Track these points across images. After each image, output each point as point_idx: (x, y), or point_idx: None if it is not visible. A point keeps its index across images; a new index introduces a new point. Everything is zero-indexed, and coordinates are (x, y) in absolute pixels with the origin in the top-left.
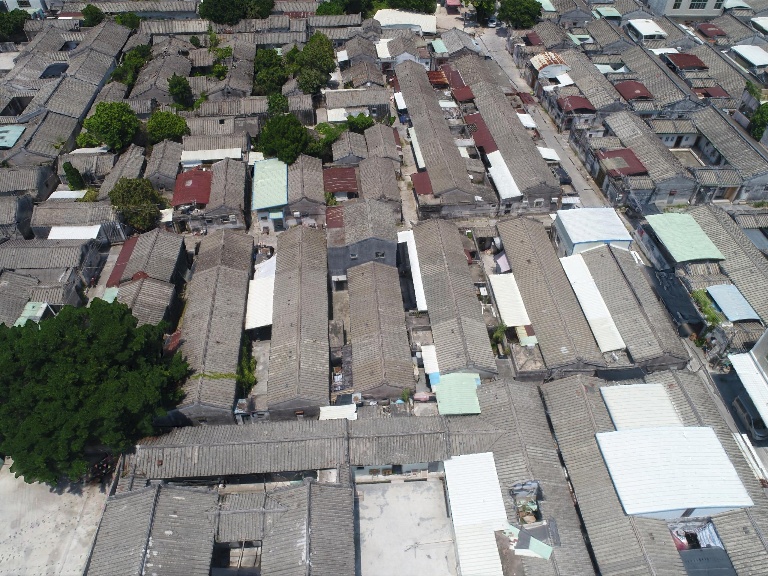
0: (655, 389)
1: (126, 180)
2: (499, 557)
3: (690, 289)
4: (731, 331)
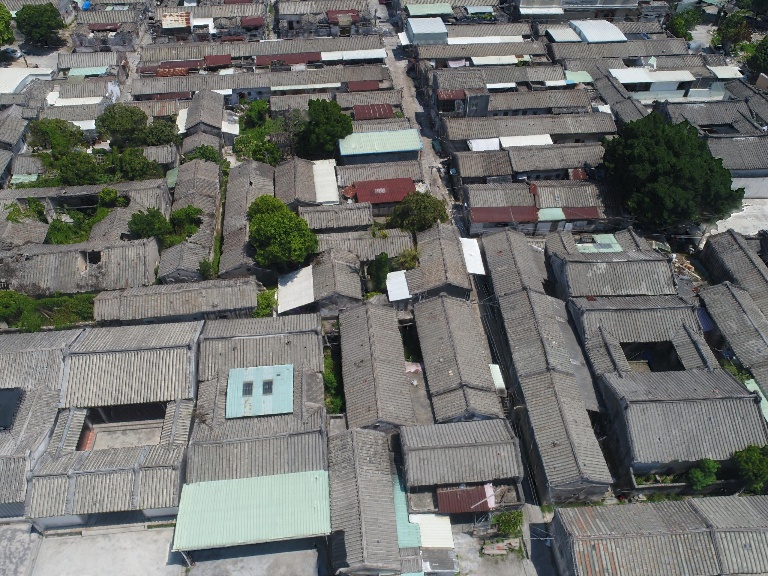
0: (551, 30)
1: (414, 201)
2: (661, 71)
3: (469, 17)
4: (514, 4)
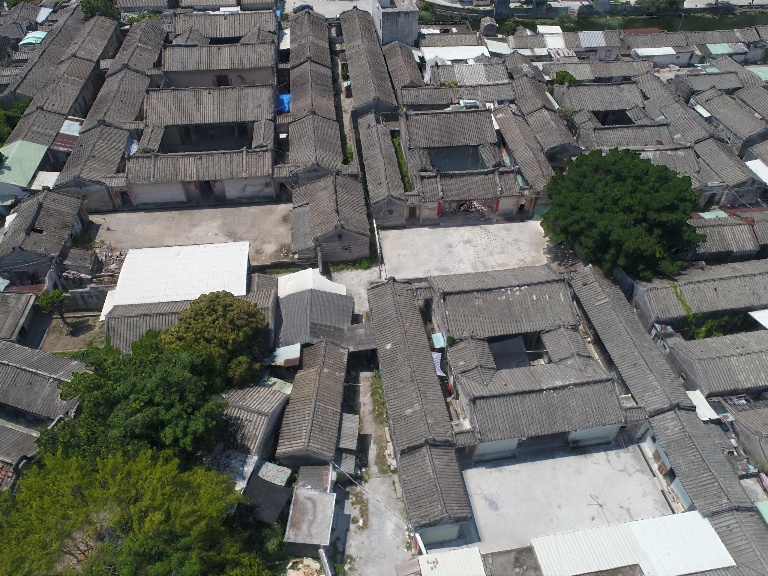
0: None
1: None
2: (612, 567)
3: None
4: None
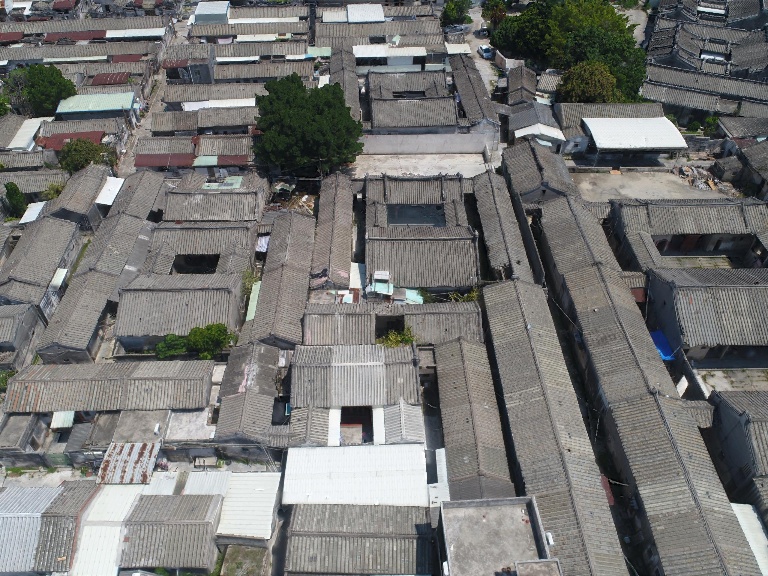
0: None
1: (69, 145)
2: (399, 48)
3: (265, 2)
4: None
